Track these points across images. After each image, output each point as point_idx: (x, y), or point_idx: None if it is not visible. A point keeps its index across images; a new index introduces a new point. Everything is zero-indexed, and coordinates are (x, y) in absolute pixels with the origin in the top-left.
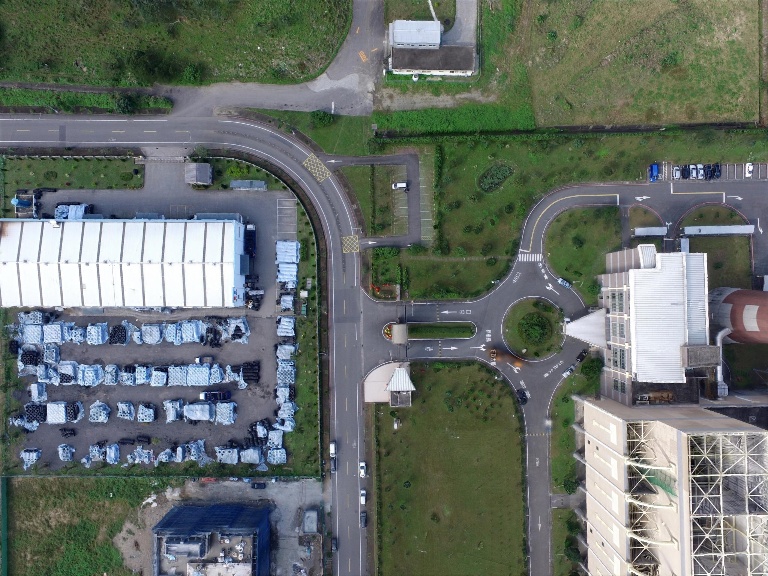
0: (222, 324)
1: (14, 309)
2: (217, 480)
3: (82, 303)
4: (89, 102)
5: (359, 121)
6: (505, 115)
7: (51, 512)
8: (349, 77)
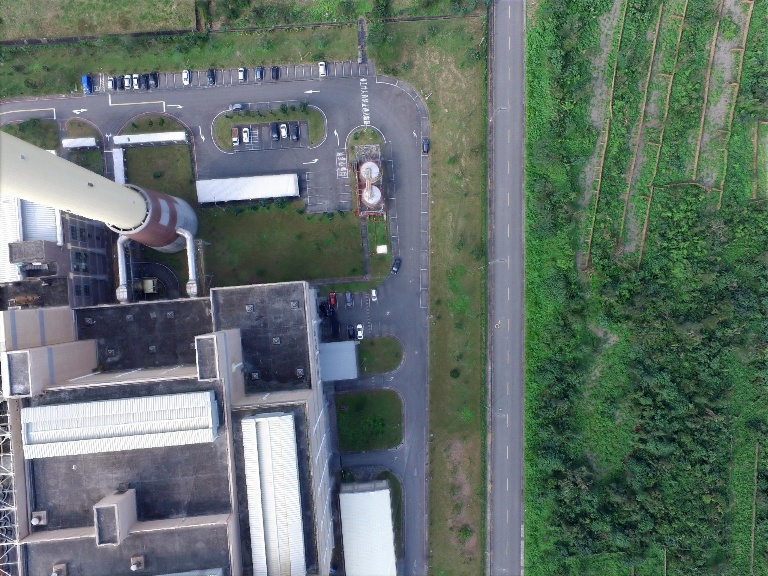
0: None
1: None
2: None
3: None
4: None
5: None
6: None
7: None
8: None
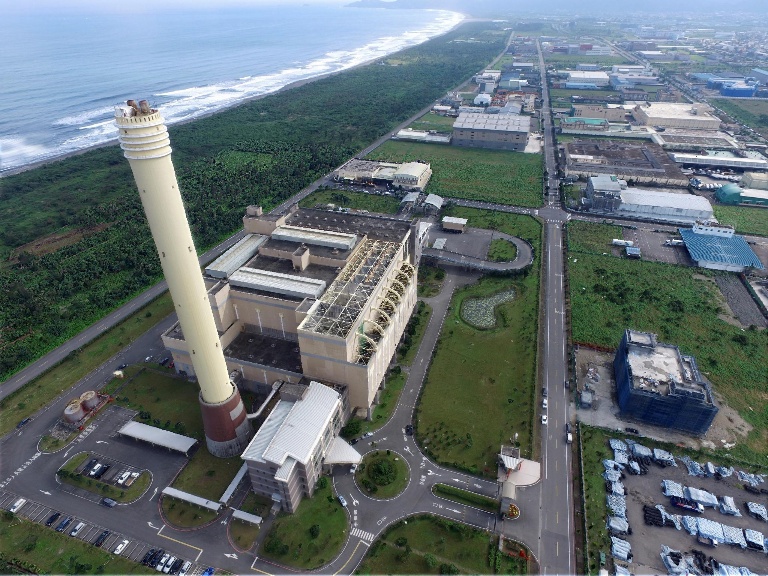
0: (696, 574)
1: None
2: None
3: None
4: None
5: None
6: None
7: None
8: None
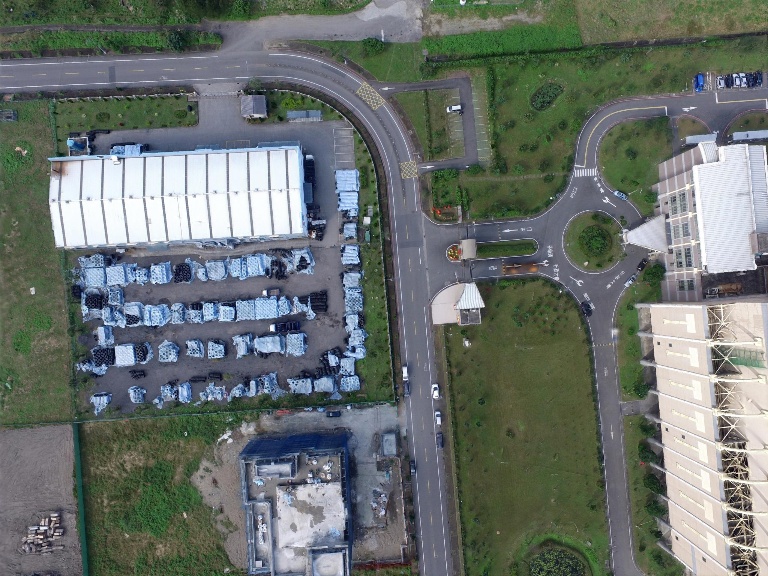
0: (286, 256)
1: (74, 254)
2: (292, 412)
3: (148, 238)
4: (138, 41)
5: (409, 48)
6: (552, 34)
7: (125, 456)
8: (397, 5)
